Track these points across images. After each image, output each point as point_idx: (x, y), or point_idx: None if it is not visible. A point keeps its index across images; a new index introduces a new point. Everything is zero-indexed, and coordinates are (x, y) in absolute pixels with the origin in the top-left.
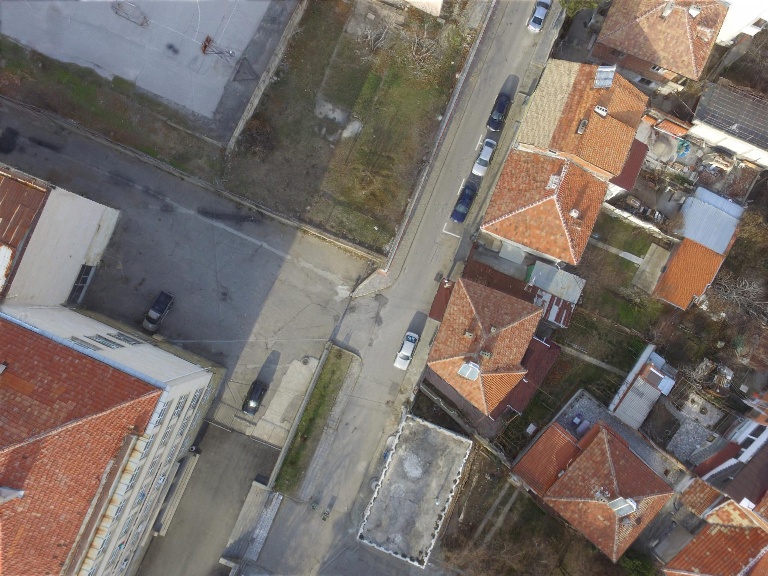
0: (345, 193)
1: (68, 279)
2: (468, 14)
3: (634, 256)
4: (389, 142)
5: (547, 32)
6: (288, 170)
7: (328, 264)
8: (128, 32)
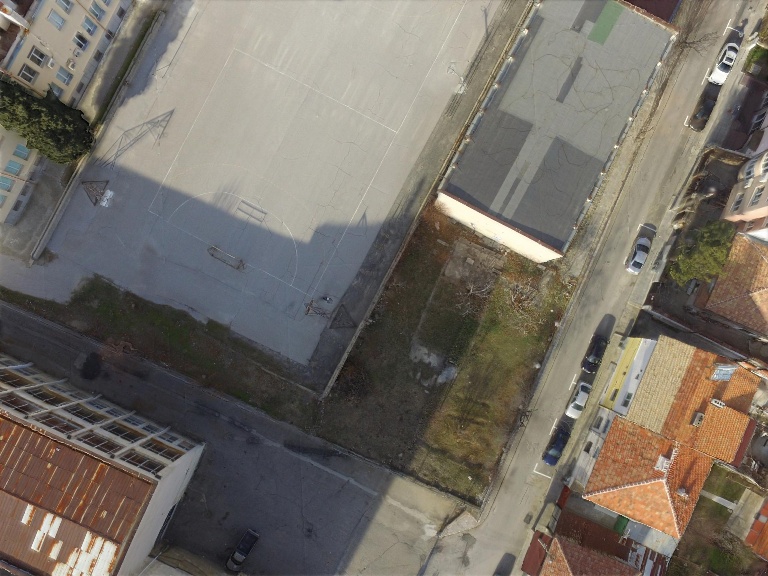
0: (439, 441)
1: (157, 531)
2: (569, 262)
3: (727, 501)
4: (485, 389)
5: (645, 273)
6: (381, 416)
7: (416, 502)
8: (224, 275)
